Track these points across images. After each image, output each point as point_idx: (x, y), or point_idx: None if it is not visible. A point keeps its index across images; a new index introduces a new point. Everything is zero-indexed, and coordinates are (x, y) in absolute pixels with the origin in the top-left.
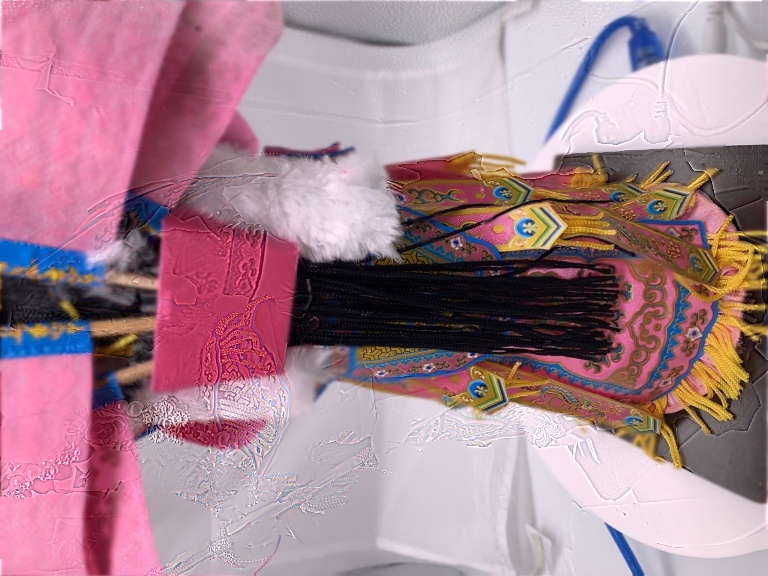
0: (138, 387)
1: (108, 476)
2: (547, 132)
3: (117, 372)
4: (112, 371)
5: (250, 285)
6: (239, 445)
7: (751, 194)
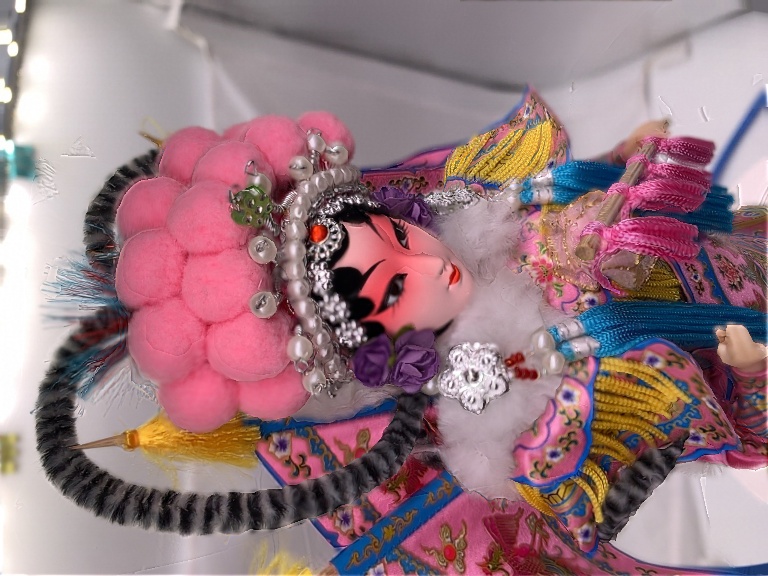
0: None
1: None
2: None
3: None
4: None
5: None
6: None
7: (732, 191)
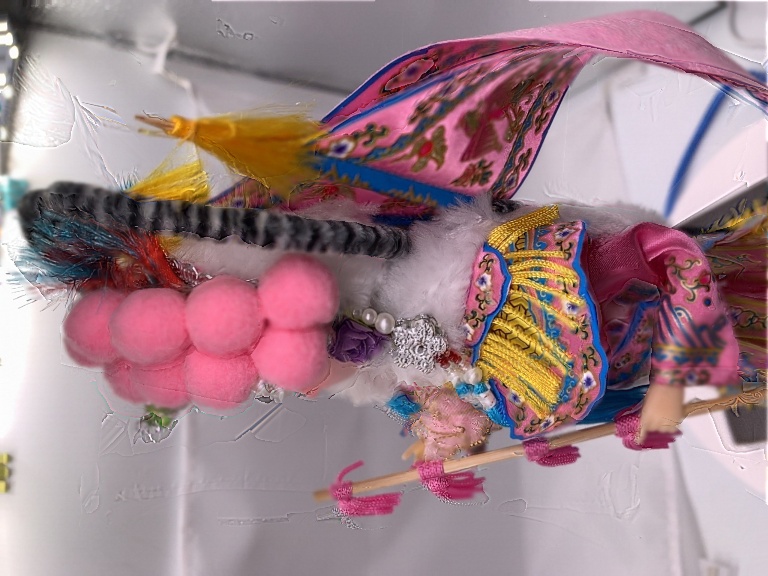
0: (385, 294)
1: (332, 389)
2: (767, 16)
3: (373, 275)
4: (368, 273)
5: (516, 181)
6: (491, 386)
7: None
